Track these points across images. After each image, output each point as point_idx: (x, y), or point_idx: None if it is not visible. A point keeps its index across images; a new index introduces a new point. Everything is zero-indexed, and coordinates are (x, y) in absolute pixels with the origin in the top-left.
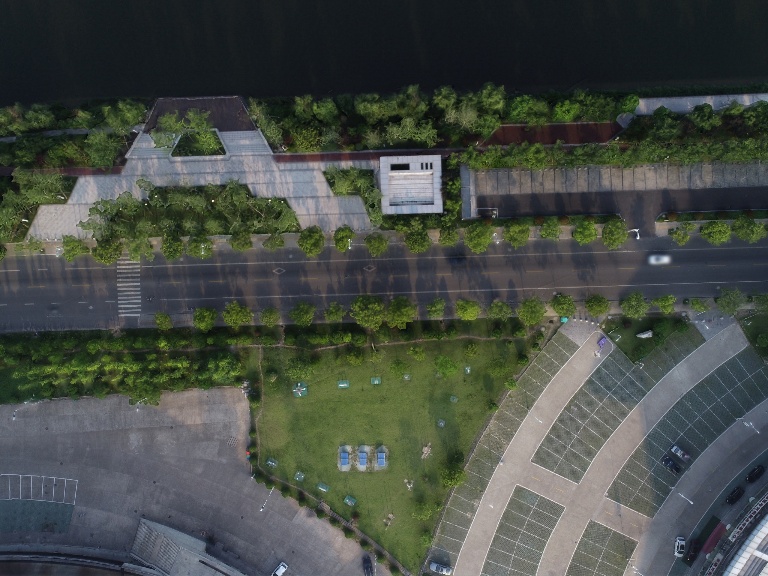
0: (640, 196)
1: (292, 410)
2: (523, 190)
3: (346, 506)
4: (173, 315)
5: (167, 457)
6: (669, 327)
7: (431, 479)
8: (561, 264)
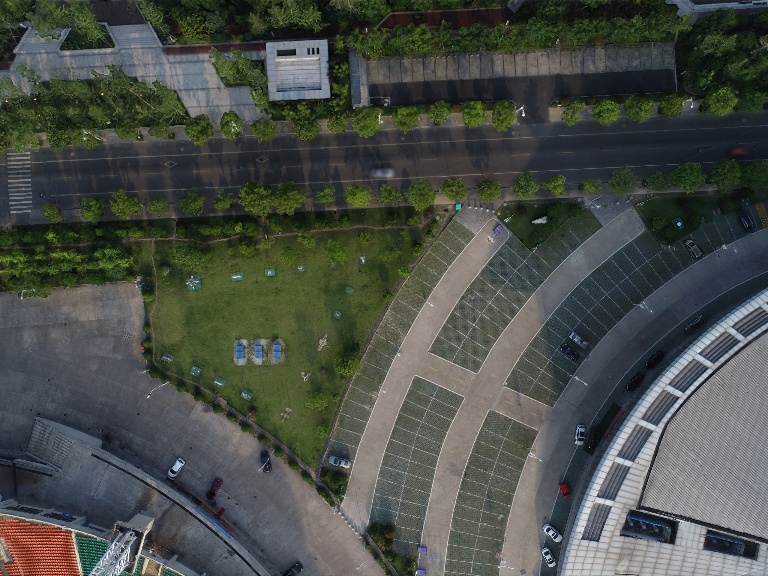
0: (533, 82)
1: (186, 304)
2: (415, 78)
3: (243, 400)
4: (65, 211)
5: (61, 354)
6: (565, 213)
7: (328, 371)
8: (455, 152)
